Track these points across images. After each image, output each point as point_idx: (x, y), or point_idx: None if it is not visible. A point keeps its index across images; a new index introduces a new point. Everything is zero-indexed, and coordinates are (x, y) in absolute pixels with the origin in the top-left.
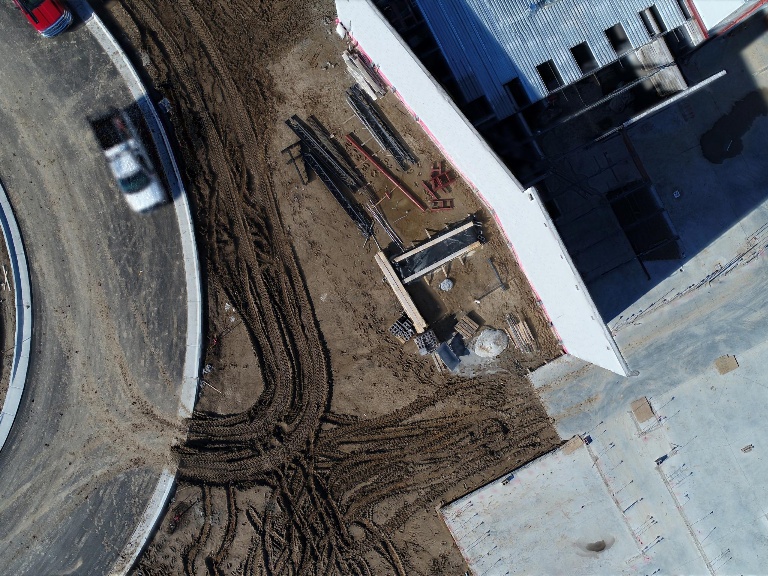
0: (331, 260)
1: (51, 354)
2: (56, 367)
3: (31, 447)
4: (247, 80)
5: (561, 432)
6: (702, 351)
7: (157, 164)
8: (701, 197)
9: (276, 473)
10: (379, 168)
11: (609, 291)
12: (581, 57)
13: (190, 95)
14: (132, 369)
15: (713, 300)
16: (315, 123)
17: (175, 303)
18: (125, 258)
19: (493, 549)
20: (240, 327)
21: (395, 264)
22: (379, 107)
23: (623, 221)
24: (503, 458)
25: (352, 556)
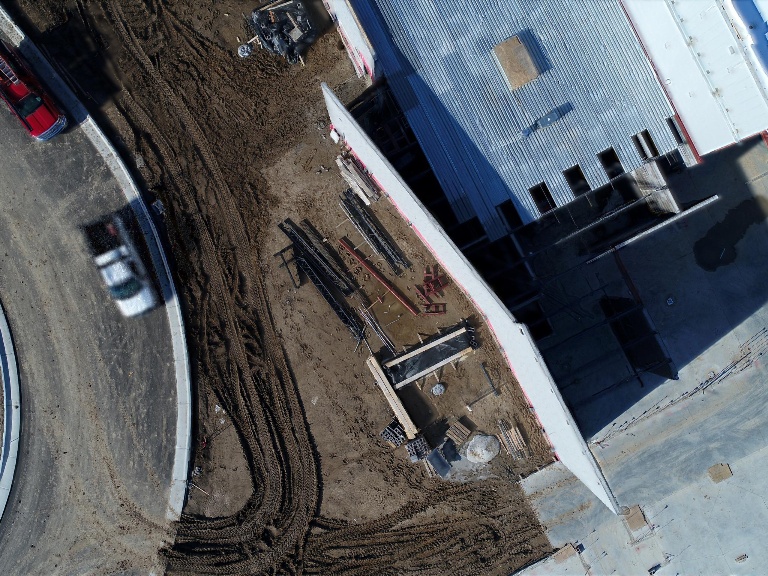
0: (322, 363)
1: (39, 454)
2: (44, 468)
3: (17, 548)
4: (240, 183)
5: (553, 540)
6: (696, 459)
7: (149, 265)
8: (694, 304)
9: None
10: (371, 272)
11: (602, 398)
12: (573, 179)
13: (183, 197)
14: (120, 471)
15: (706, 408)
16: (308, 227)
17: (165, 405)
18: (115, 359)
19: None
20: (230, 429)
21: (387, 369)
22: (372, 211)
23: (616, 328)
24: (494, 565)
25: None
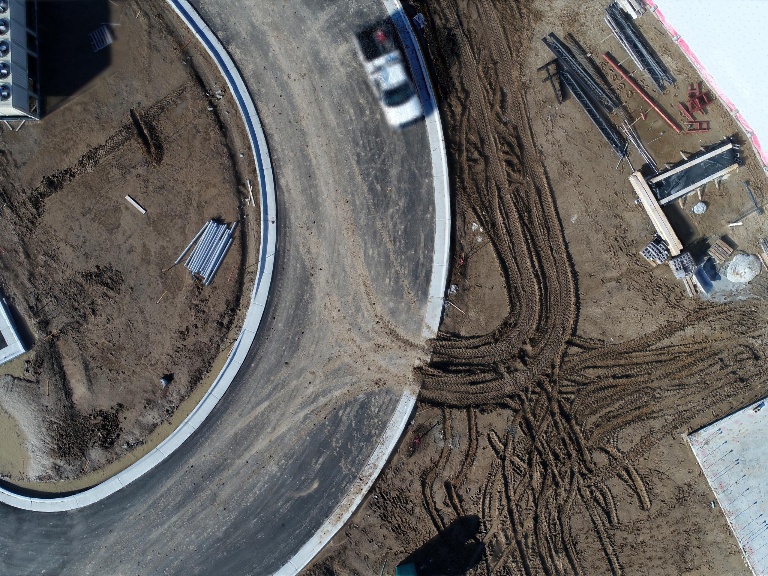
0: (583, 181)
1: (294, 271)
2: (299, 284)
3: (270, 365)
4: None
5: None
6: None
7: (409, 80)
8: None
9: (519, 397)
10: (636, 88)
11: None
12: None
13: (444, 11)
14: (376, 288)
15: None
16: (572, 41)
17: (423, 221)
18: (373, 175)
19: (741, 478)
20: (487, 247)
21: (652, 185)
22: (637, 26)
23: None
24: (753, 386)
25: (594, 483)
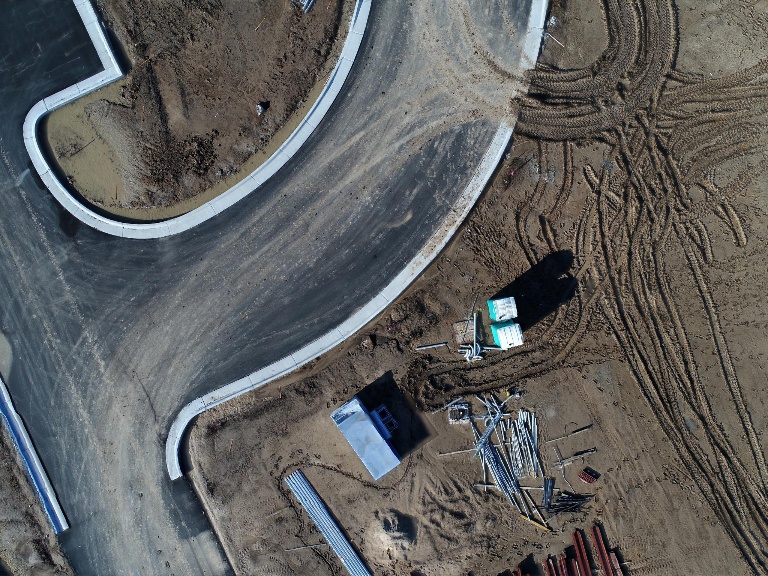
0: None
1: (394, 0)
2: (398, 14)
3: (367, 95)
4: None
5: None
6: None
7: None
8: None
9: (616, 131)
10: None
11: None
12: None
13: None
14: (475, 18)
15: None
16: None
17: None
18: None
19: None
20: None
21: None
22: None
23: None
24: None
25: (690, 220)
